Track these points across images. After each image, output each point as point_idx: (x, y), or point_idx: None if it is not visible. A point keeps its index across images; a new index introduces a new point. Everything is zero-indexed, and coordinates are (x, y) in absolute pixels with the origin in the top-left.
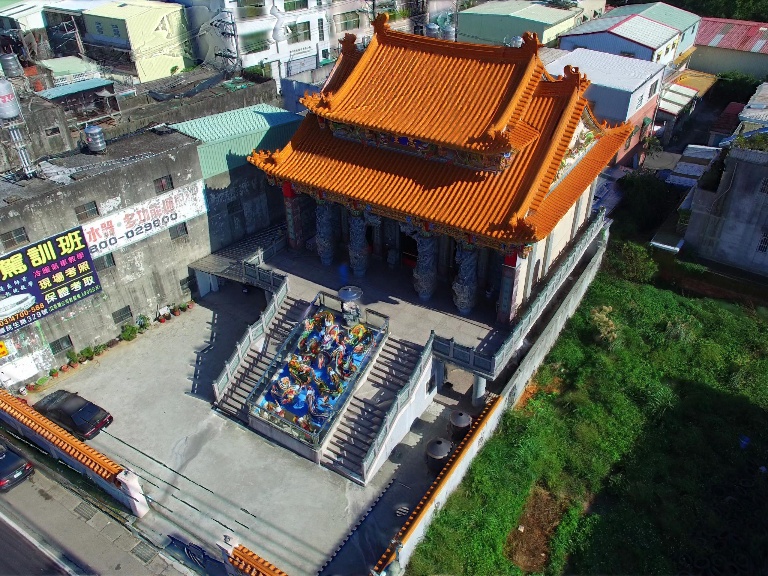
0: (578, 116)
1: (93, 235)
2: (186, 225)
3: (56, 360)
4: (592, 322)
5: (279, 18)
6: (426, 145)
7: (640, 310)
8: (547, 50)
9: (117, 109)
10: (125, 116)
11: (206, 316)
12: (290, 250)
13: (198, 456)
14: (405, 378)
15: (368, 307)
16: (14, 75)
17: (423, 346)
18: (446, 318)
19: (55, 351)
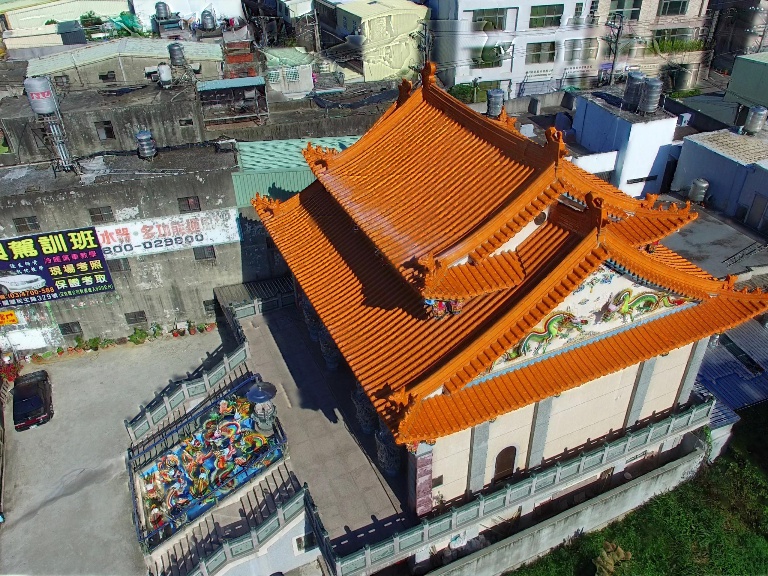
0: (583, 273)
1: (107, 238)
2: (214, 249)
3: (65, 340)
4: (593, 560)
5: (490, 36)
6: None
7: (695, 575)
8: None
9: (266, 110)
10: (278, 117)
11: (212, 345)
12: (295, 308)
13: (73, 495)
14: None
15: (302, 412)
16: (178, 64)
17: None
18: (365, 468)
19: (66, 332)
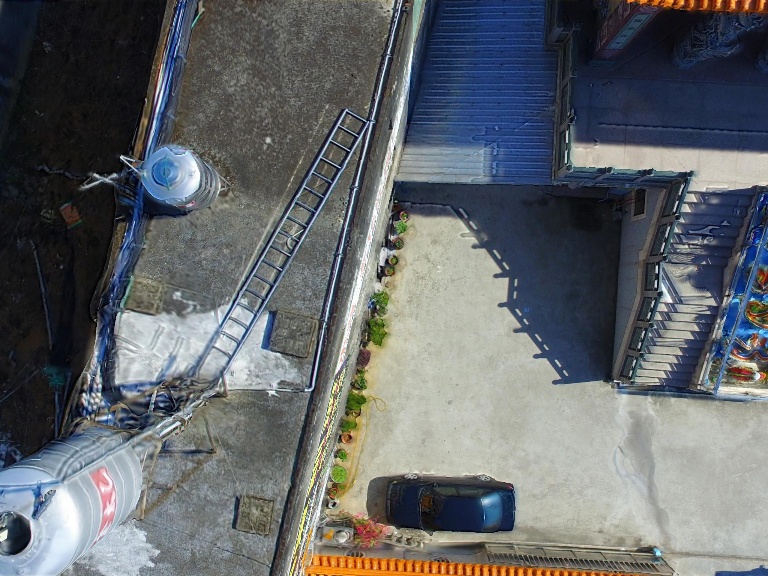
0: None
1: None
2: None
3: None
4: None
5: None
6: None
7: None
8: None
9: None
10: None
11: (448, 223)
12: (594, 63)
13: (658, 465)
14: None
15: None
16: None
17: None
18: None
19: None
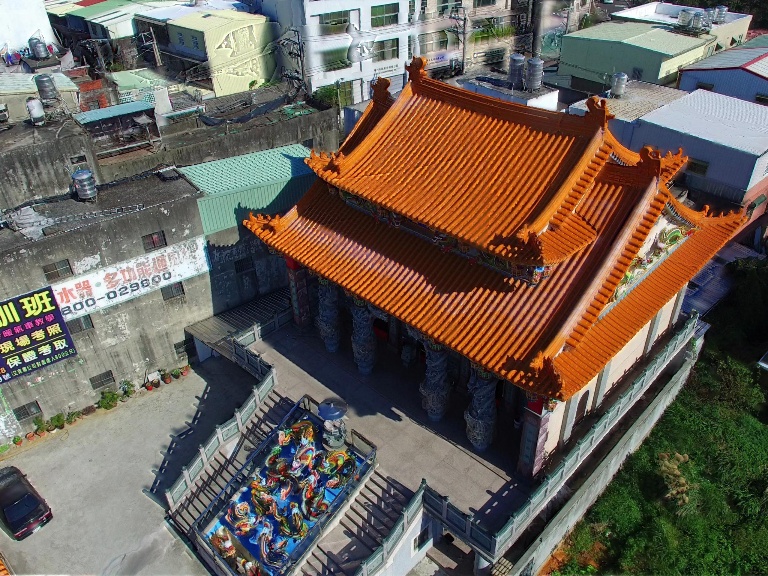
0: (653, 217)
1: (66, 296)
2: (183, 285)
3: (21, 426)
4: (658, 471)
5: (355, 37)
6: (444, 235)
7: (730, 459)
8: (659, 89)
9: (157, 135)
10: (168, 142)
11: (197, 388)
12: (294, 326)
13: None
14: (384, 533)
15: (362, 420)
16: (49, 97)
17: (414, 492)
18: (454, 452)
19: (21, 417)
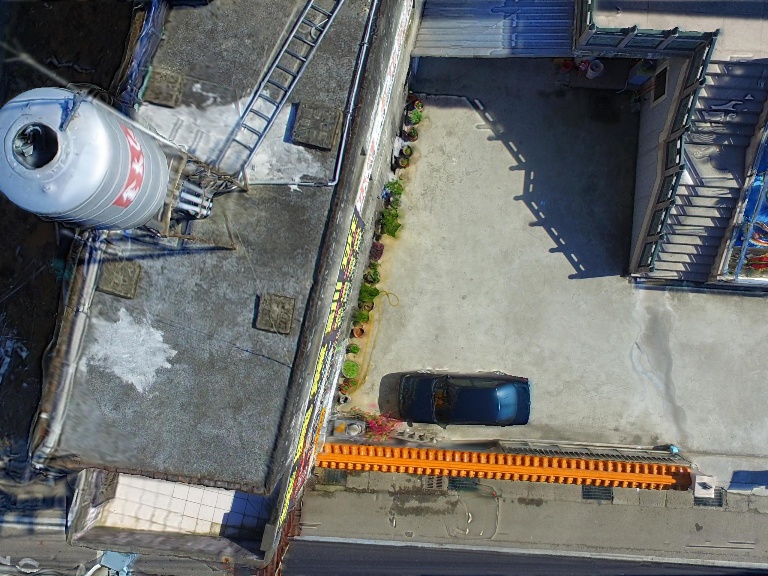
0: None
1: None
2: None
3: None
4: None
5: None
6: None
7: None
8: None
9: None
10: None
11: (464, 115)
12: None
13: (675, 362)
14: None
15: None
16: None
17: None
18: None
19: None
